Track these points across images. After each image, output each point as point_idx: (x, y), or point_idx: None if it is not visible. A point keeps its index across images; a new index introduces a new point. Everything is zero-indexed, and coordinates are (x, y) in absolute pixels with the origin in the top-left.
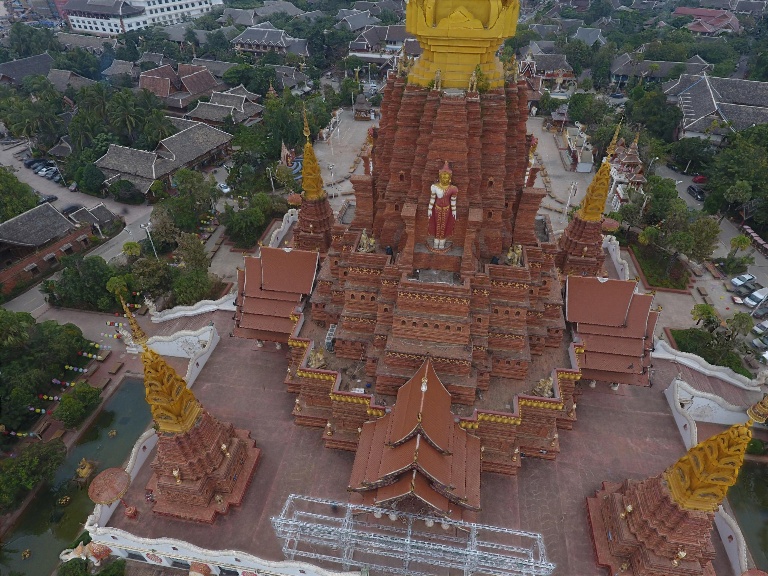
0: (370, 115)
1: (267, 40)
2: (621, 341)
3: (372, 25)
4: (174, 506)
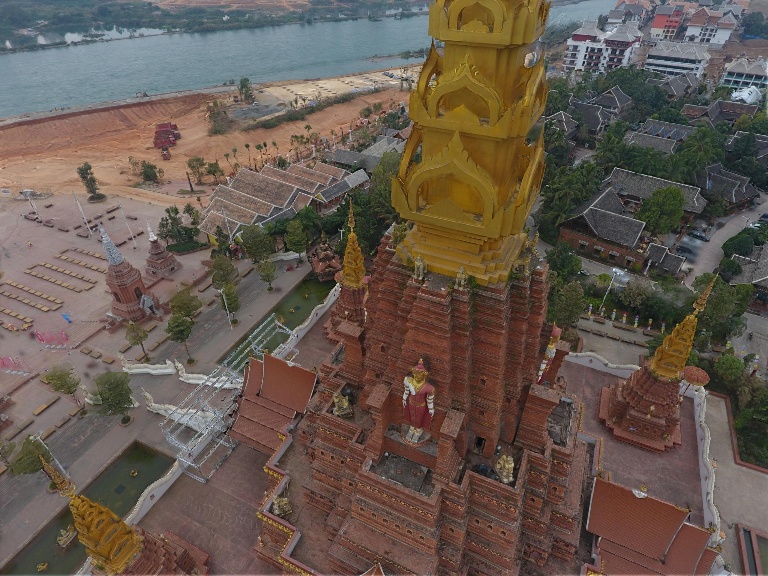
0: None
1: None
2: None
3: None
4: None
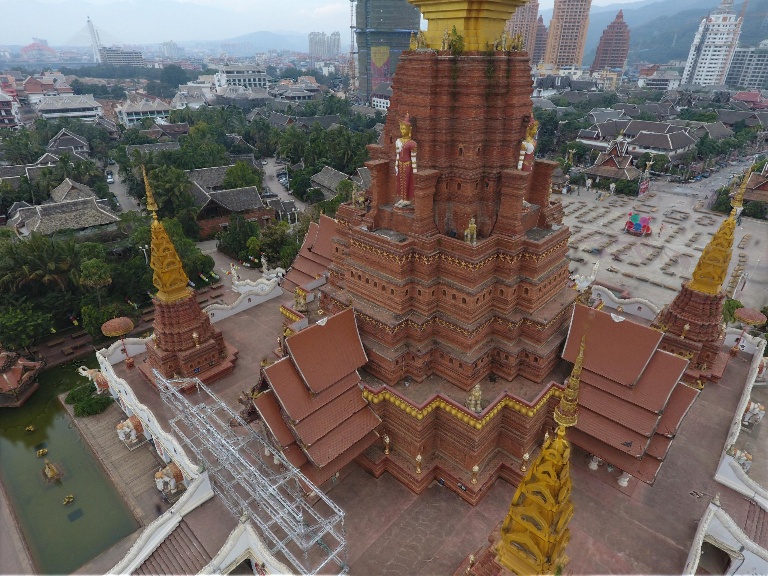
0: (562, 189)
1: None
2: (626, 407)
3: (614, 119)
4: (151, 370)
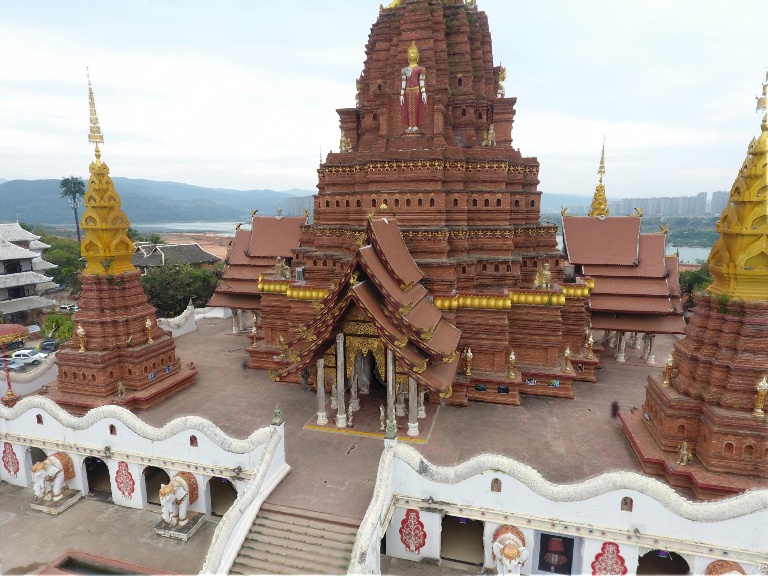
0: None
1: None
2: None
3: None
4: None
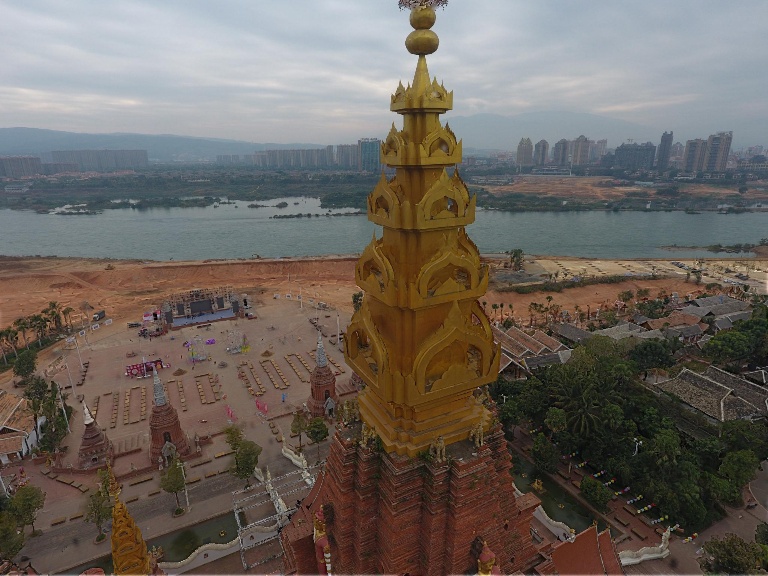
0: None
1: None
2: None
3: None
4: None
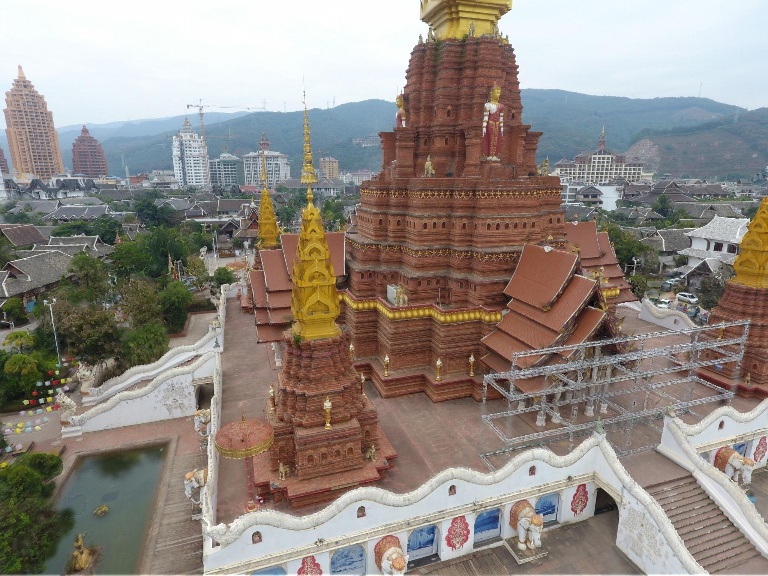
0: (235, 252)
1: (88, 215)
2: (605, 269)
3: None
4: (317, 482)
